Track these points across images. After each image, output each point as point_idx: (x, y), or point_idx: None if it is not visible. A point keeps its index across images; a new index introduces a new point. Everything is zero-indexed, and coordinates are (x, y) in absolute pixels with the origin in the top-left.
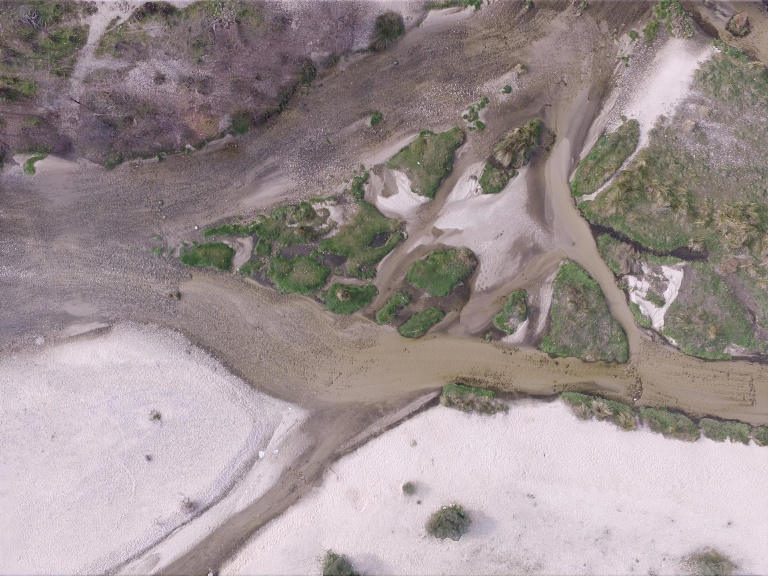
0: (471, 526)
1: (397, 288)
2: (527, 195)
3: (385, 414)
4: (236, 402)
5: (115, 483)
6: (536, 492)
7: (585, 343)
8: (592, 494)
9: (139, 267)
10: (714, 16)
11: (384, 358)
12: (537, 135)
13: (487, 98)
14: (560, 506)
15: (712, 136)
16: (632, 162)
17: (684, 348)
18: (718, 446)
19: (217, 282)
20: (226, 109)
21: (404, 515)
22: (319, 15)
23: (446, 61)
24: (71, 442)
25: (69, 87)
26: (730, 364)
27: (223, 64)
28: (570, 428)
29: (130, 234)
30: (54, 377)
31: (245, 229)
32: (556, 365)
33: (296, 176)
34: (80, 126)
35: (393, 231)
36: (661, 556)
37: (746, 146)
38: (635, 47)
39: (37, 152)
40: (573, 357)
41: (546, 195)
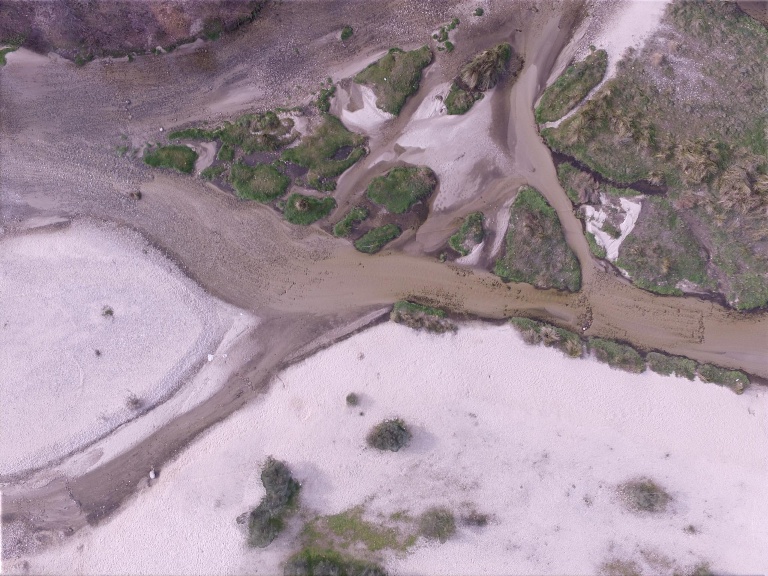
0: (412, 441)
1: (356, 202)
2: (491, 118)
3: (335, 326)
4: (188, 303)
5: (64, 375)
6: (478, 412)
7: (538, 269)
8: (533, 417)
9: (102, 165)
10: None
11: (338, 271)
12: (504, 58)
13: (458, 19)
14: (501, 427)
15: (679, 71)
16: (598, 92)
17: (636, 281)
18: (663, 380)
19: (178, 185)
20: (198, 13)
21: (346, 425)
22: None
23: None
24: (23, 331)
25: None
26: (681, 300)
27: None
28: (517, 352)
29: (96, 131)
30: (11, 267)
31: (209, 133)
32: (508, 290)
33: (263, 85)
34: (53, 20)
35: (356, 145)
36: (598, 483)
37: (712, 83)
38: None
39: (9, 44)
40: (526, 283)
41: (510, 120)
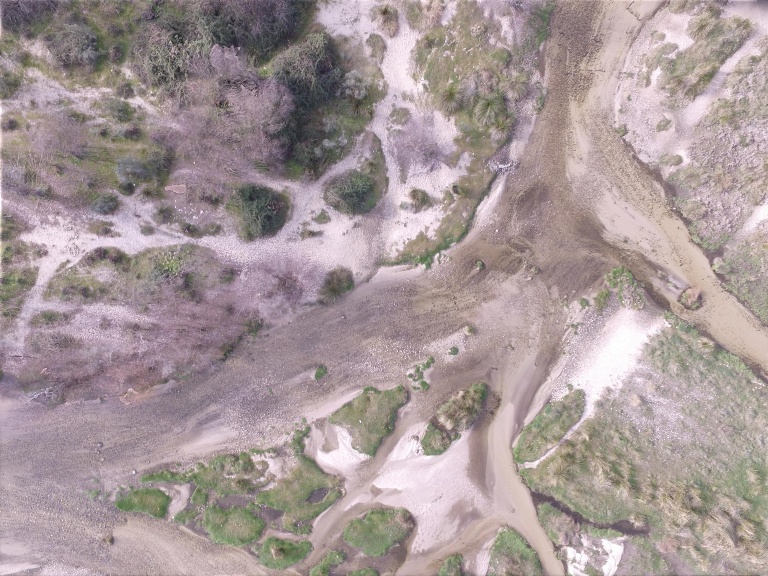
0: None
1: (332, 545)
2: (469, 458)
3: None
4: None
5: None
6: None
7: None
8: None
9: (74, 508)
10: (666, 288)
11: None
12: (480, 403)
13: (433, 358)
14: None
15: (658, 412)
16: (576, 432)
17: None
18: None
19: (152, 528)
20: (171, 355)
21: None
22: (268, 267)
23: (394, 318)
24: None
25: (15, 327)
26: None
27: (169, 312)
28: None
29: (67, 475)
30: None
31: (182, 478)
32: None
33: (237, 425)
34: (24, 365)
35: (331, 487)
36: None
37: (692, 424)
38: (585, 315)
39: None
40: None
41: (488, 460)
